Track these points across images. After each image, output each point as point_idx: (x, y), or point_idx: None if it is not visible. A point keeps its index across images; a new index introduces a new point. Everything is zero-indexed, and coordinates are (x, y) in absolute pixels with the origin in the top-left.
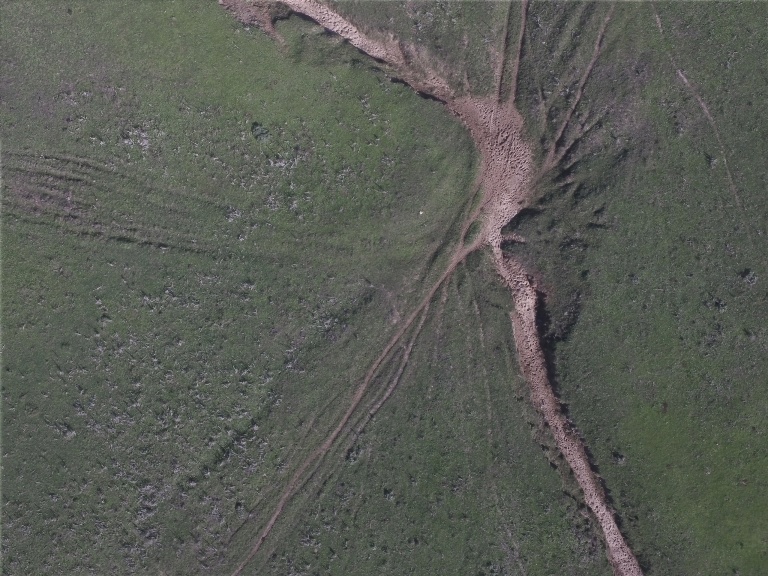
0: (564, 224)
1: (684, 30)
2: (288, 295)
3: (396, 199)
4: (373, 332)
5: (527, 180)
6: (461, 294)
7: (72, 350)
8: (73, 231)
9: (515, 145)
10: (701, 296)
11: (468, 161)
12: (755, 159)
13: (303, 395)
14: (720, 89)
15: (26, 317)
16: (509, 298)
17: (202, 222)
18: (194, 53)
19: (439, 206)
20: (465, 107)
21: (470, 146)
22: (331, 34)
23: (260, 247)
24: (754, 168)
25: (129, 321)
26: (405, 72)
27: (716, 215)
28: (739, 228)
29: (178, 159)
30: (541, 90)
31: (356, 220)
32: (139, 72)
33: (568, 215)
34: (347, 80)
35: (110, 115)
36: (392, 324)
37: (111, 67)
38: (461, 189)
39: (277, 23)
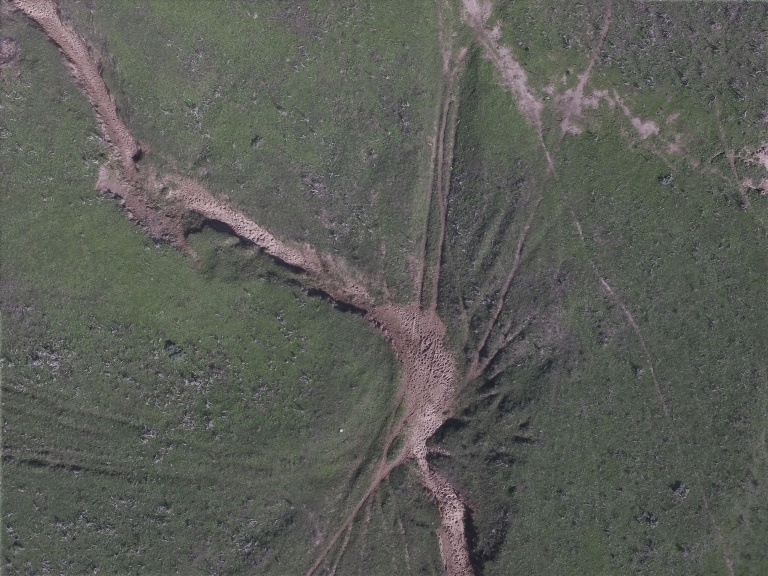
0: (489, 437)
1: (606, 237)
2: (206, 518)
3: (315, 418)
4: (295, 555)
5: (451, 390)
6: (385, 513)
7: None
8: None
9: (438, 353)
10: (631, 511)
11: (389, 374)
12: (682, 367)
13: None
14: (644, 296)
15: None
16: (435, 514)
17: (116, 444)
18: (104, 270)
19: (360, 422)
20: (386, 314)
21: (391, 358)
22: (246, 245)
23: (176, 468)
24: (682, 376)
25: (42, 548)
26: (324, 280)
27: (644, 426)
28: (668, 439)
29: (90, 379)
30: (462, 299)
31: (274, 440)
32: (48, 291)
33: (493, 428)
34: (262, 295)
35: (19, 335)
36: (315, 546)
37: (19, 286)
38: (383, 403)
39: (189, 237)
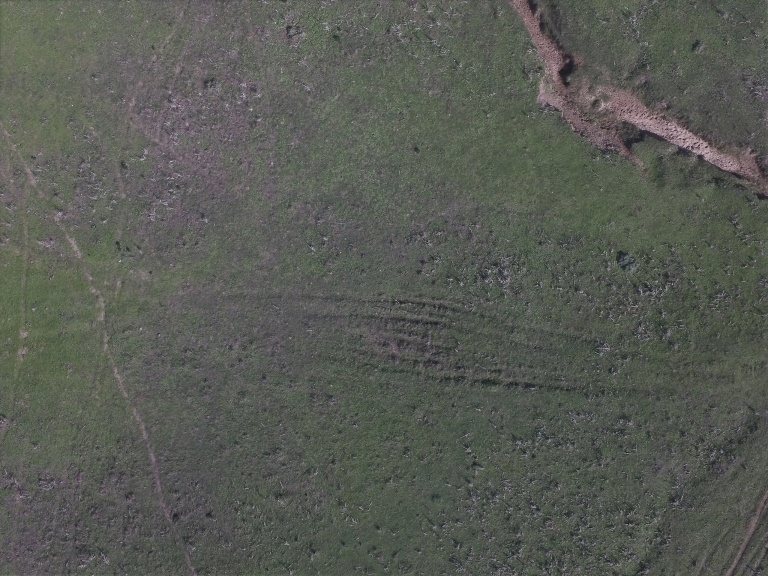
0: None
1: None
2: (668, 429)
3: None
4: (761, 461)
5: None
6: None
7: (443, 502)
8: (435, 377)
9: None
10: None
11: None
12: None
13: (693, 533)
14: None
15: (392, 471)
16: None
17: (570, 358)
18: (550, 184)
19: None
20: None
21: None
22: (687, 153)
23: (633, 380)
24: None
25: (501, 467)
26: (763, 185)
27: None
28: None
29: (541, 295)
30: None
31: (736, 346)
32: (494, 207)
33: None
34: (714, 201)
35: (466, 254)
36: None
37: (464, 204)
38: None
39: (634, 146)
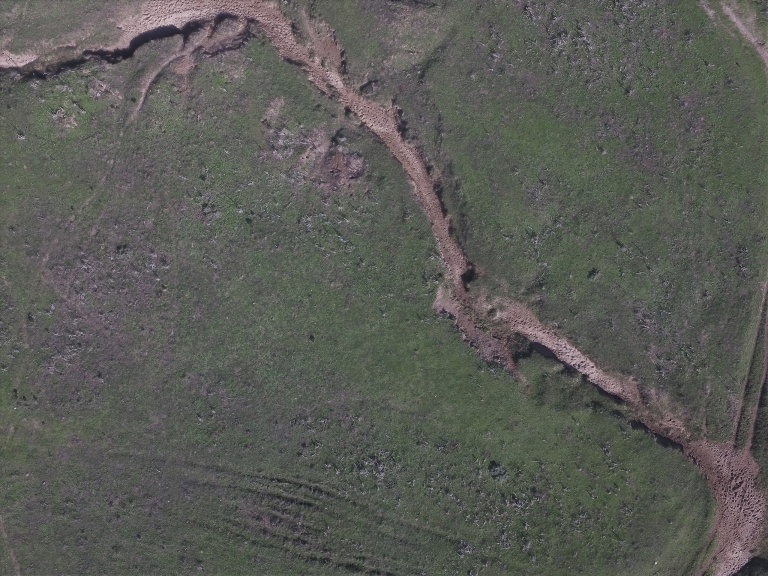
0: None
1: None
2: None
3: (632, 549)
4: None
5: (760, 529)
6: None
7: None
8: (302, 556)
9: (749, 493)
10: None
11: (704, 510)
12: None
13: None
14: None
15: None
16: None
17: (433, 556)
18: (435, 387)
19: (673, 555)
20: (700, 450)
21: (707, 496)
22: (571, 373)
23: None
24: None
25: None
26: (641, 412)
27: None
28: None
29: (412, 492)
30: None
31: (590, 567)
32: (378, 403)
33: None
34: (589, 425)
35: (346, 443)
36: None
37: (350, 396)
38: (695, 538)
39: (520, 362)
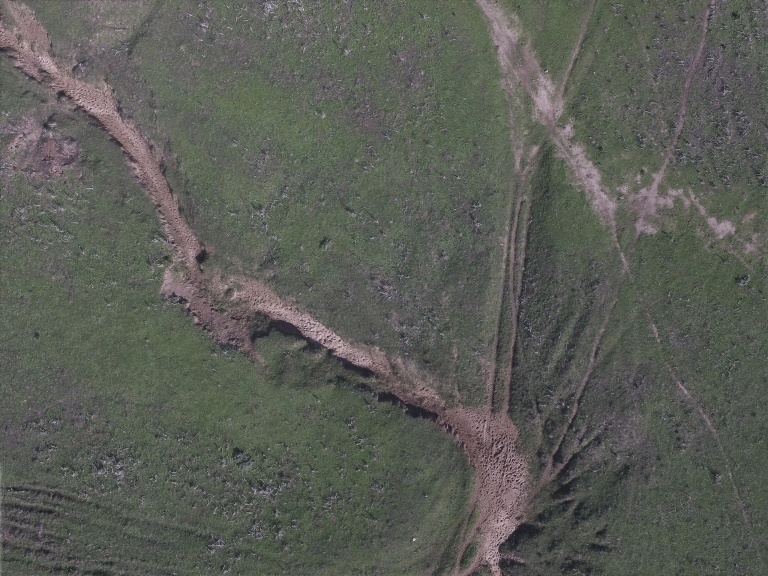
0: (565, 544)
1: (682, 340)
2: None
3: (387, 527)
4: None
5: (524, 494)
6: None
7: None
8: (45, 567)
9: (510, 457)
10: None
11: (462, 480)
12: (761, 472)
13: None
14: (722, 400)
15: None
16: None
17: (183, 554)
18: (170, 376)
19: (433, 529)
20: (457, 417)
21: (463, 464)
22: (314, 348)
23: None
24: (761, 481)
25: None
26: (393, 383)
27: (723, 533)
28: (748, 546)
29: (155, 488)
30: (536, 402)
31: (346, 550)
32: (112, 397)
33: (569, 535)
34: (332, 402)
35: (82, 443)
36: None
37: (82, 393)
38: (455, 509)
39: (256, 342)
